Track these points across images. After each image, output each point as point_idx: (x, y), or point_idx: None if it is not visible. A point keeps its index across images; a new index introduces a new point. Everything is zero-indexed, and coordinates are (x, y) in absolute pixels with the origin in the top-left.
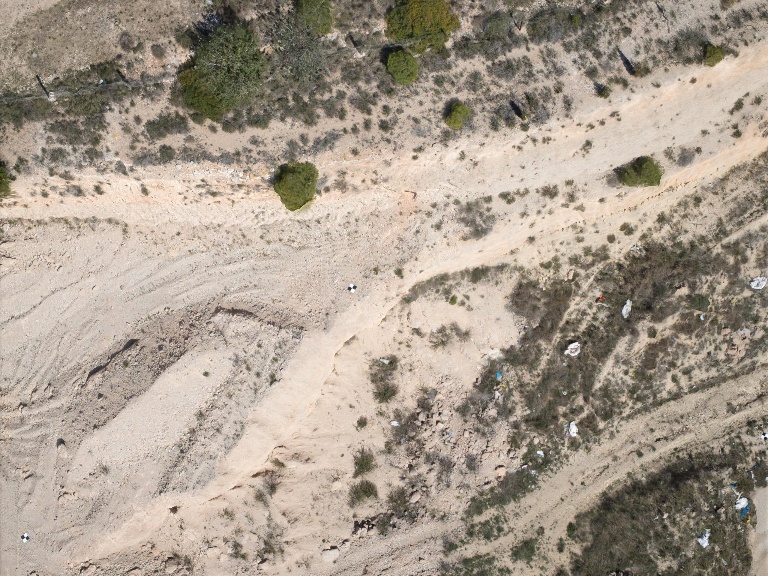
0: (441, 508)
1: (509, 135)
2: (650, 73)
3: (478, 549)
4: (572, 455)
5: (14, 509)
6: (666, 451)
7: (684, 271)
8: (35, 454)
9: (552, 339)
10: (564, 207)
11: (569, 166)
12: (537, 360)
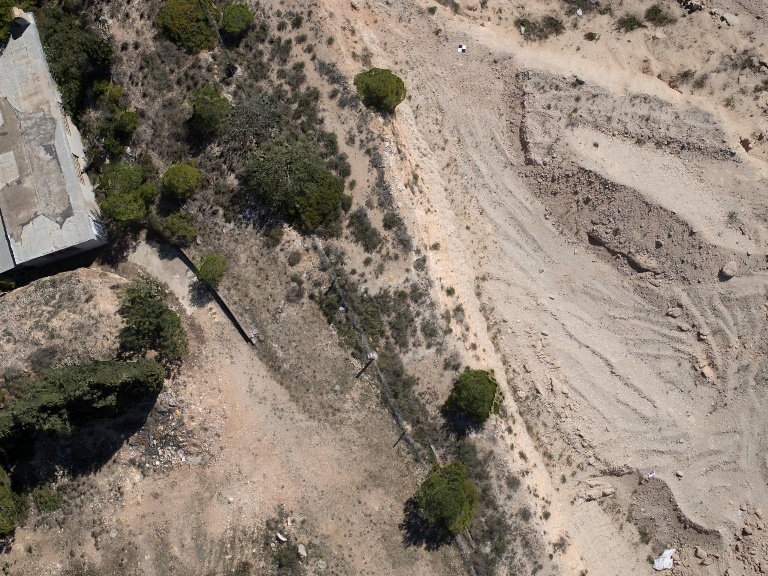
0: None
1: None
2: None
3: None
4: None
5: None
6: None
7: None
8: (745, 302)
9: None
10: None
11: None
12: None
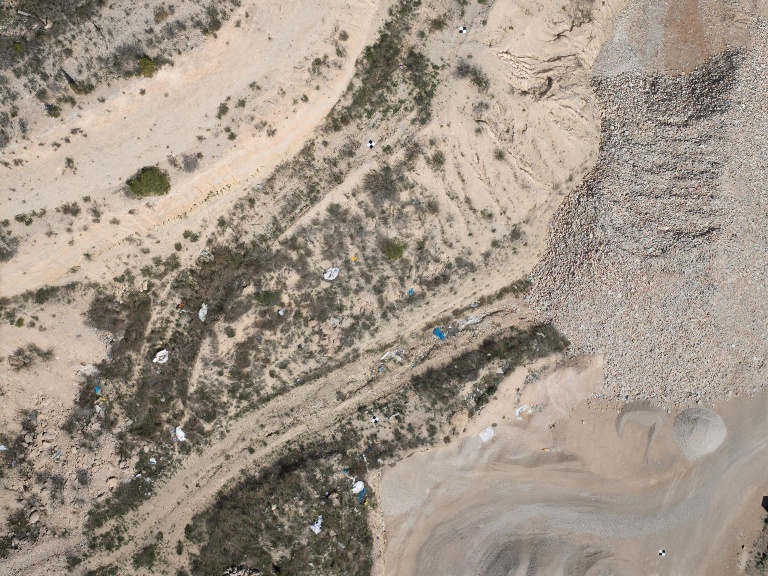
0: (61, 525)
1: None
2: (93, 89)
3: (101, 561)
4: (185, 459)
5: None
6: (278, 445)
7: (247, 270)
8: None
9: (140, 349)
10: (96, 222)
11: (67, 184)
12: (130, 371)
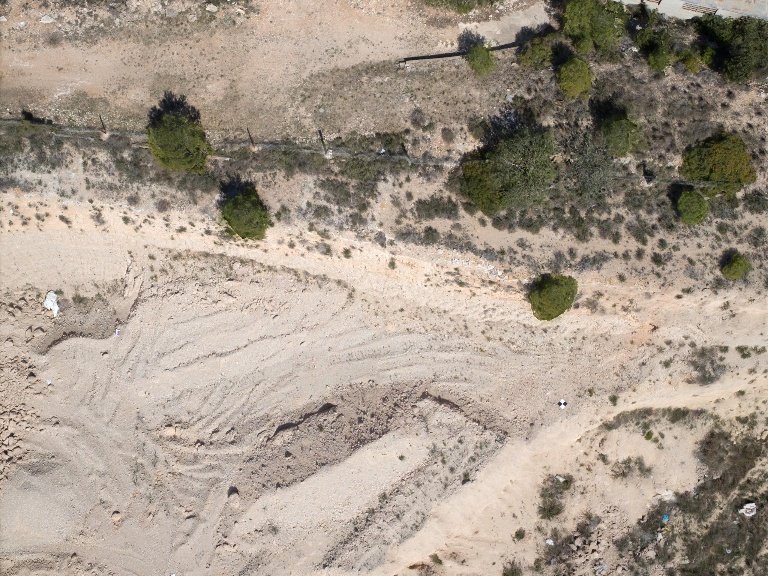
0: None
1: None
2: None
3: None
4: None
5: (168, 547)
6: None
7: None
8: (203, 496)
9: (729, 494)
10: None
11: None
12: (709, 512)
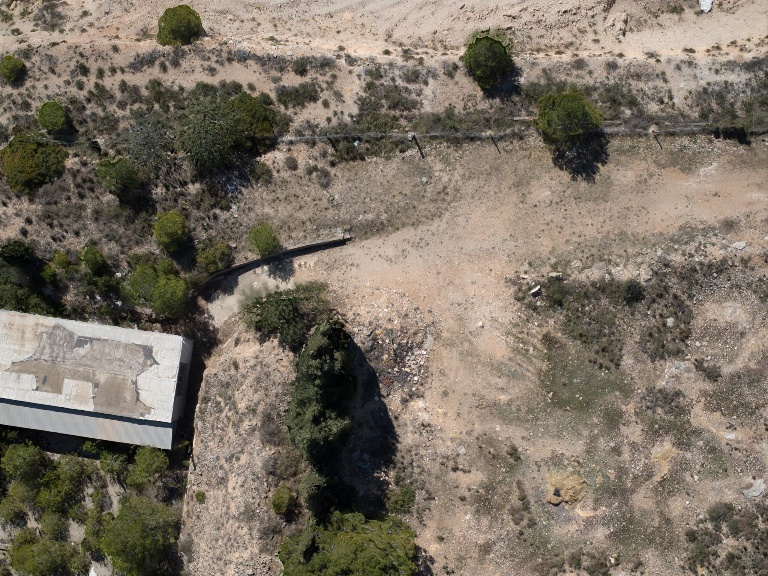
0: None
1: None
2: None
3: None
4: None
5: None
6: None
7: None
8: None
9: None
10: None
11: None
12: None
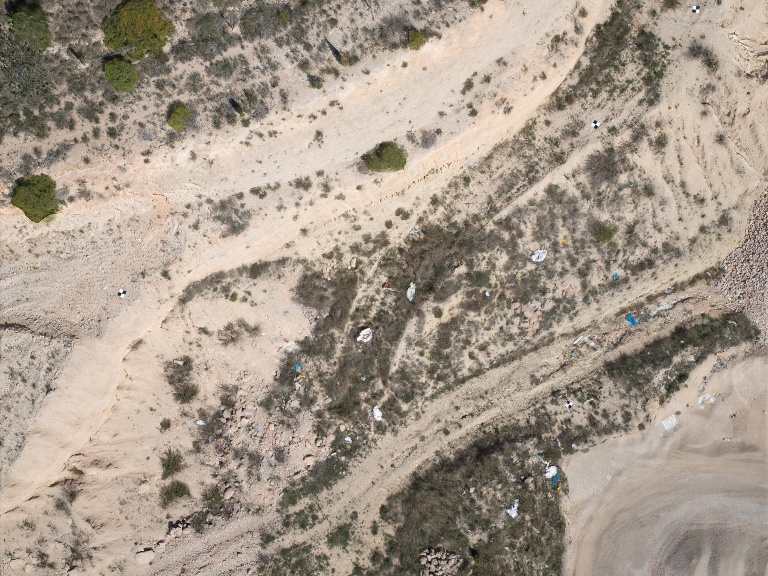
0: (255, 502)
1: (232, 132)
2: (358, 61)
3: (295, 539)
4: (380, 439)
5: None
6: (472, 427)
7: (460, 250)
8: None
9: (344, 327)
10: (323, 197)
11: (309, 157)
12: (332, 349)
